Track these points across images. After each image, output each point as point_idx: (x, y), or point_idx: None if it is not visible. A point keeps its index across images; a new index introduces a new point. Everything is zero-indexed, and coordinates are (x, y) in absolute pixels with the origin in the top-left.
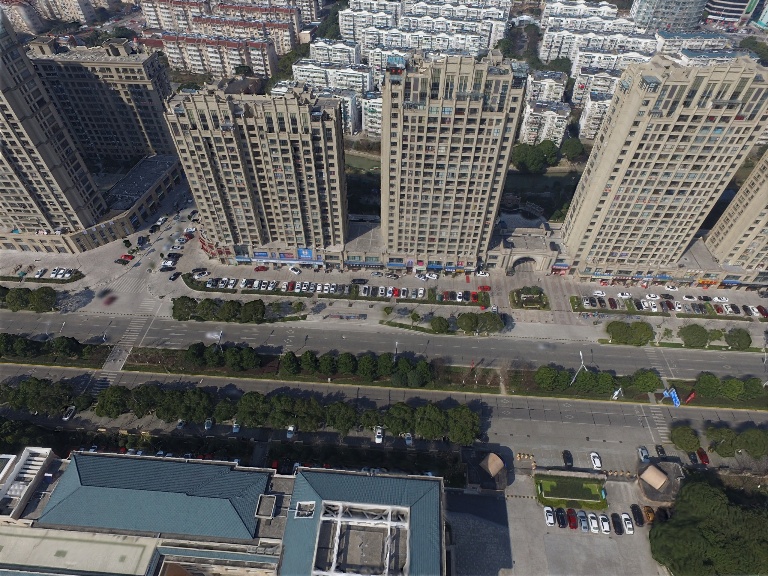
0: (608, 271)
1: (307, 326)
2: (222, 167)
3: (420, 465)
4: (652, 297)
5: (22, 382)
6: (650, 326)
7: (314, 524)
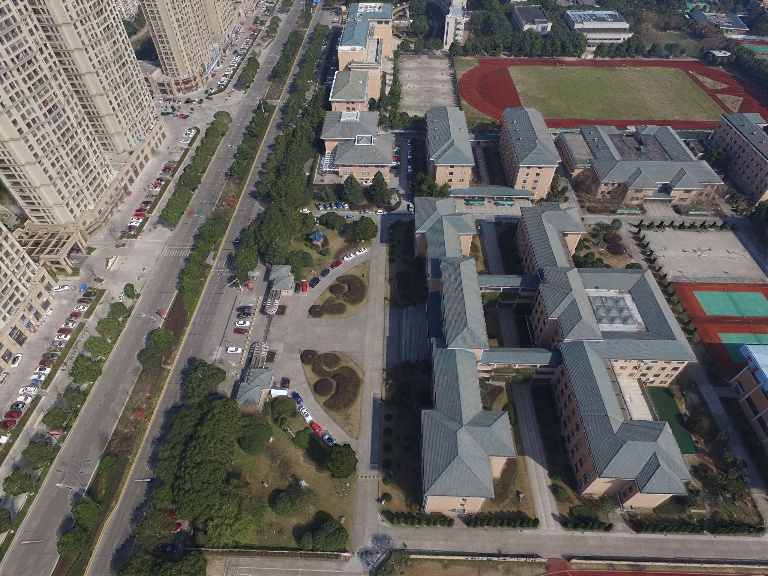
0: (253, 3)
1: (262, 63)
2: (182, 5)
3: (336, 39)
4: (267, 4)
5: (290, 102)
6: (281, 7)
7: (364, 12)
